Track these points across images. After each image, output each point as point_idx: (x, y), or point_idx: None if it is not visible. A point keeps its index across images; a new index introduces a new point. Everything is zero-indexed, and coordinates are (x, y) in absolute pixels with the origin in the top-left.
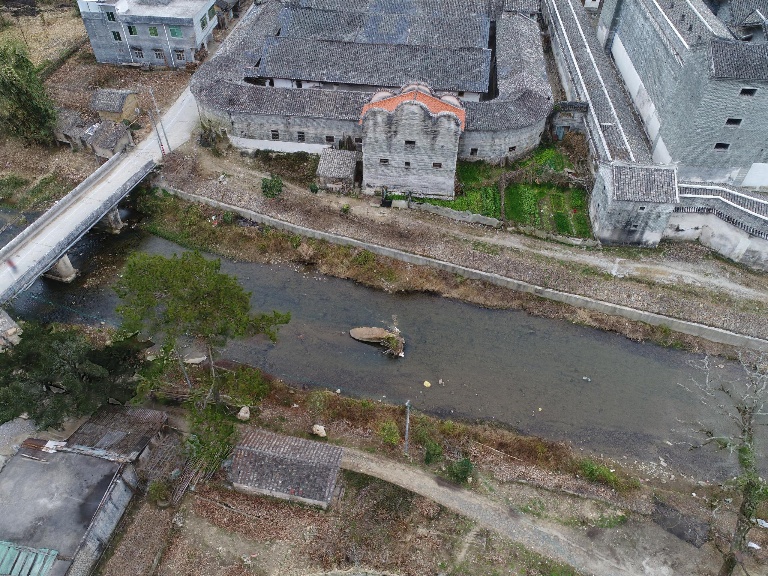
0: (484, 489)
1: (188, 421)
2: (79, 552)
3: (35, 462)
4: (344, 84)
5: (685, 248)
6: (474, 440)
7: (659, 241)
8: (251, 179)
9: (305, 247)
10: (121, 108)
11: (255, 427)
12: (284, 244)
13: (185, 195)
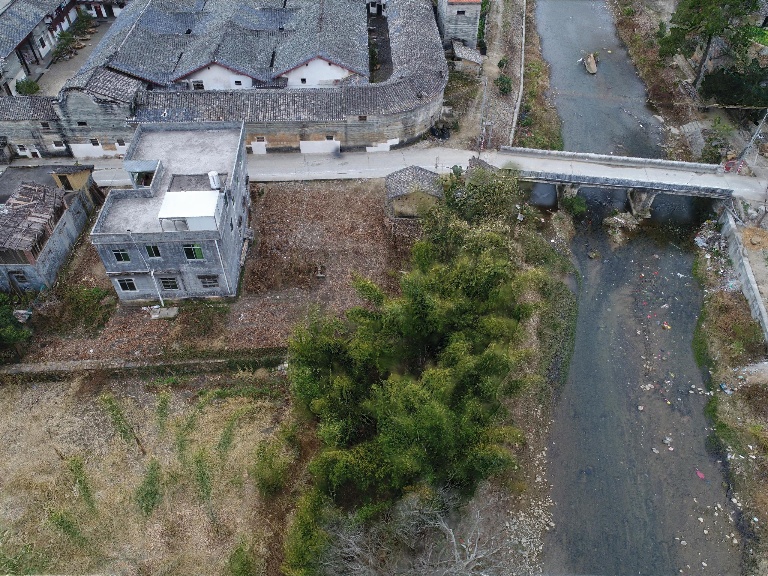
0: None
1: None
2: None
3: None
4: None
5: None
6: None
7: None
8: None
9: None
10: (435, 173)
11: None
12: None
13: None
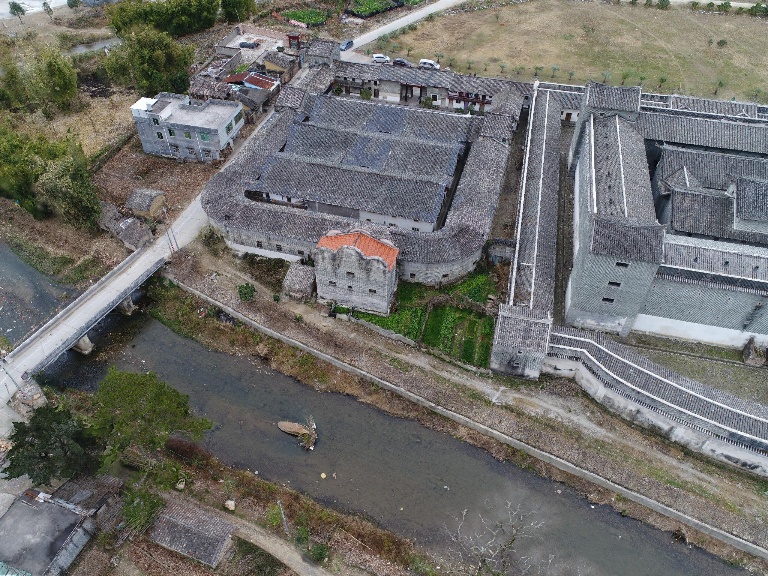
0: (334, 569)
1: (142, 484)
2: None
3: (29, 507)
4: None
5: (561, 384)
6: (341, 528)
7: None
8: (235, 280)
9: (262, 346)
10: (148, 208)
11: (186, 496)
12: (249, 339)
13: (184, 287)
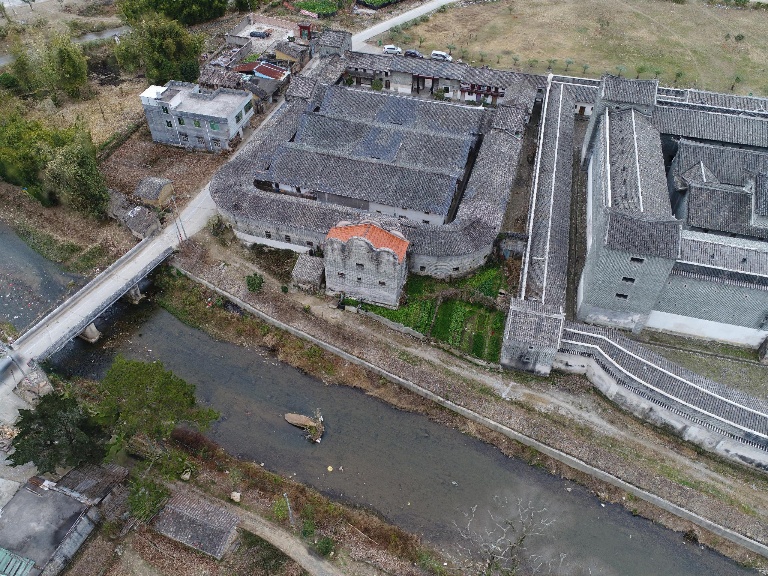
0: (340, 563)
1: None
2: (48, 564)
3: (34, 495)
4: None
5: (572, 381)
6: (348, 522)
7: None
8: (244, 270)
9: (269, 337)
10: (157, 197)
11: (192, 486)
12: (257, 330)
13: (192, 277)
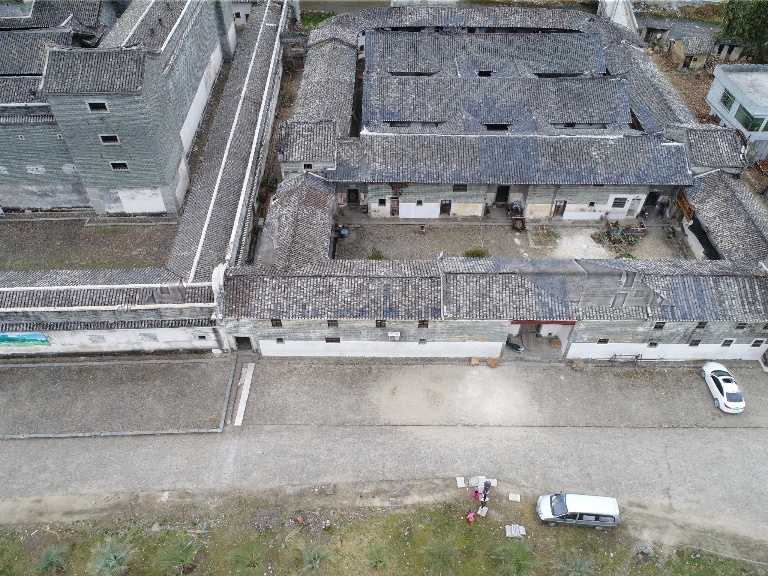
0: None
1: None
2: None
3: None
4: None
5: None
6: None
7: None
8: None
9: None
10: None
11: None
12: None
13: None
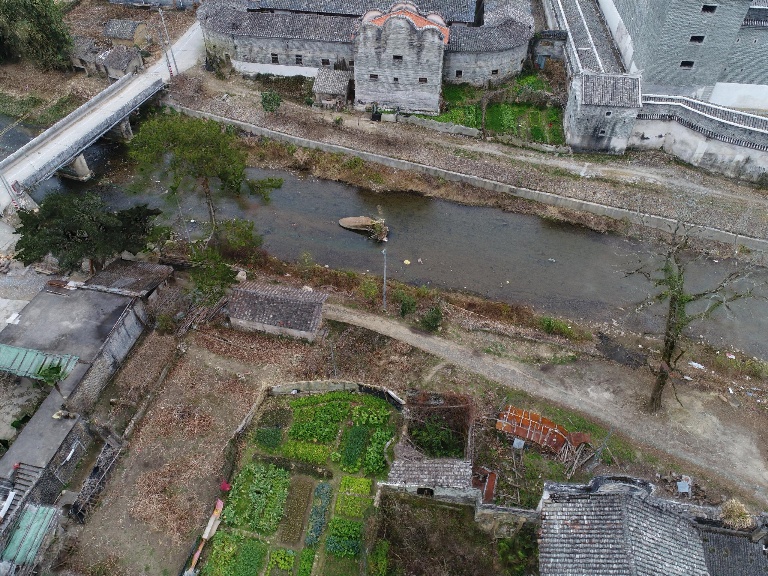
0: (452, 336)
1: (192, 282)
2: (97, 360)
3: (58, 296)
4: (340, 16)
5: (650, 155)
6: (446, 302)
7: (625, 148)
8: (252, 98)
9: (300, 153)
10: (132, 35)
11: None
12: (281, 153)
13: (191, 112)
